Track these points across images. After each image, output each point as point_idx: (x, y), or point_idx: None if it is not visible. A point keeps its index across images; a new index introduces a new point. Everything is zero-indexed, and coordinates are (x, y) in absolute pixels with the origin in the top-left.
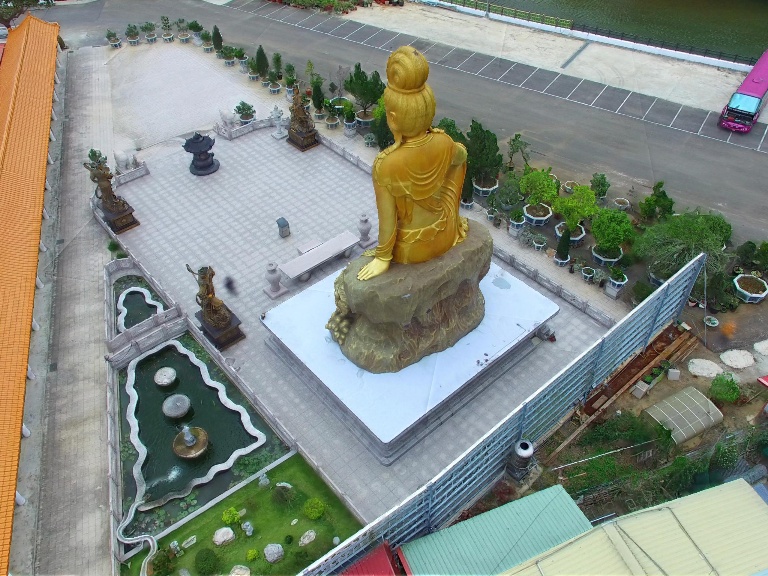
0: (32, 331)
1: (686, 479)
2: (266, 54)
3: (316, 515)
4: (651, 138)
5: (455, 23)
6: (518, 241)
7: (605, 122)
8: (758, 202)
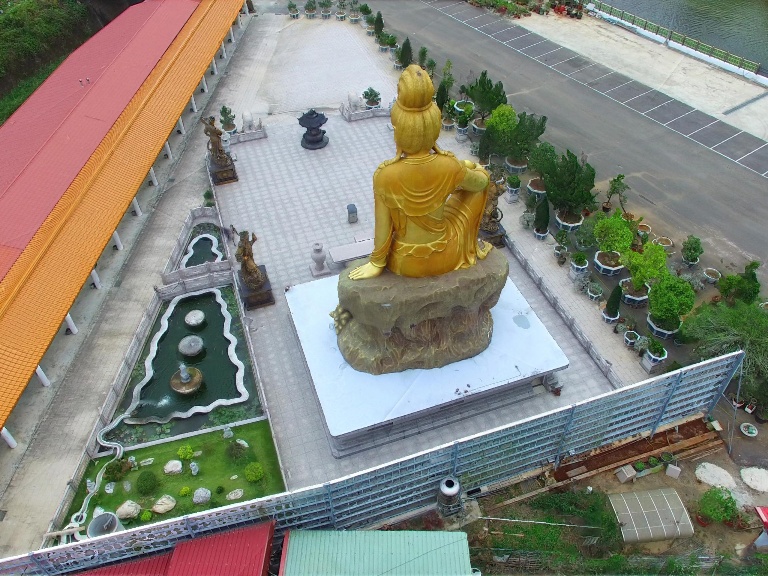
0: (116, 249)
1: None
2: None
3: (252, 478)
4: None
5: (627, 45)
6: None
7: (743, 183)
8: None
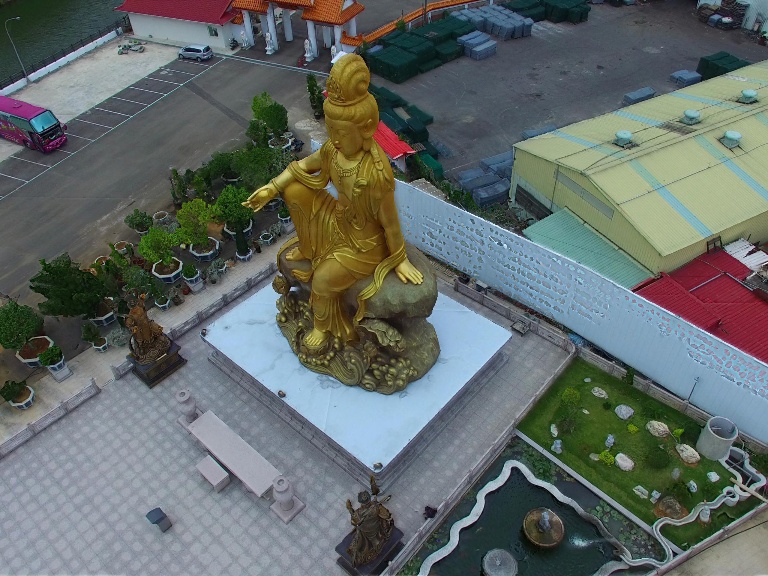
0: None
1: None
2: None
3: None
4: (46, 194)
5: None
6: (208, 287)
7: None
8: (173, 150)
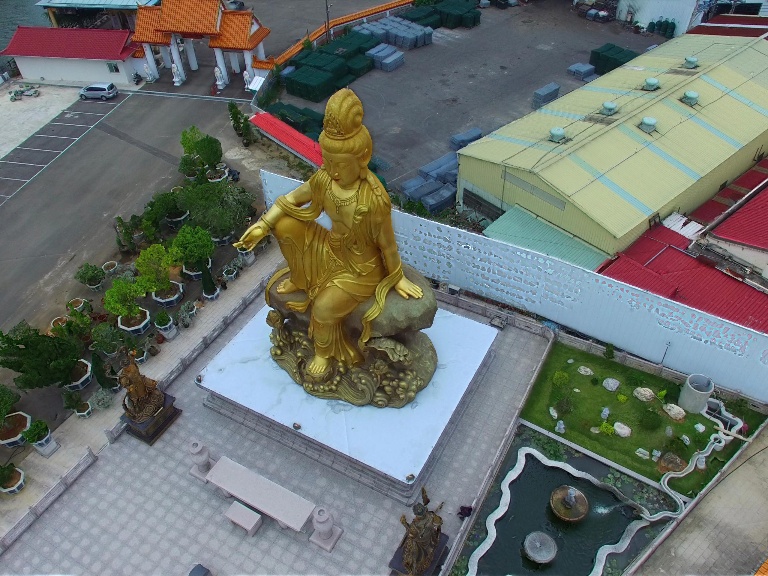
0: None
1: None
2: None
3: None
4: None
5: None
6: (182, 332)
7: None
8: (102, 196)
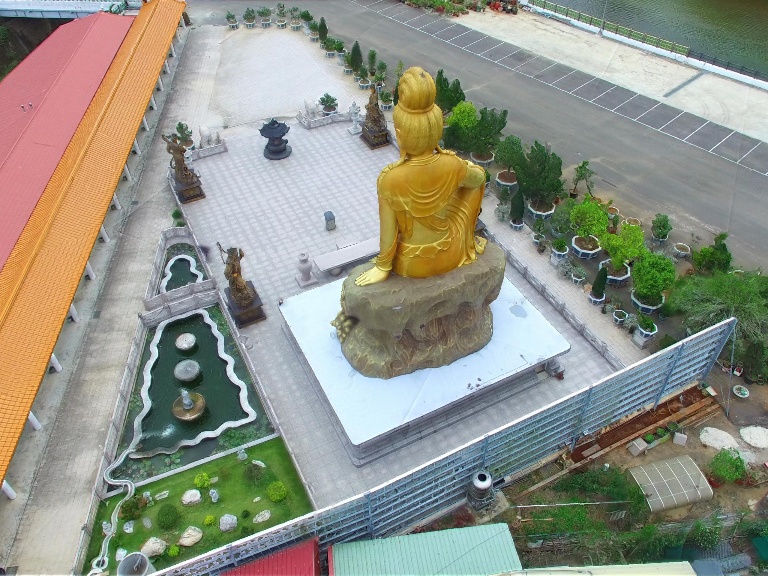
0: (89, 279)
1: (654, 549)
2: (367, 49)
3: (277, 498)
4: (740, 184)
5: (564, 37)
6: (558, 271)
7: (693, 160)
8: None
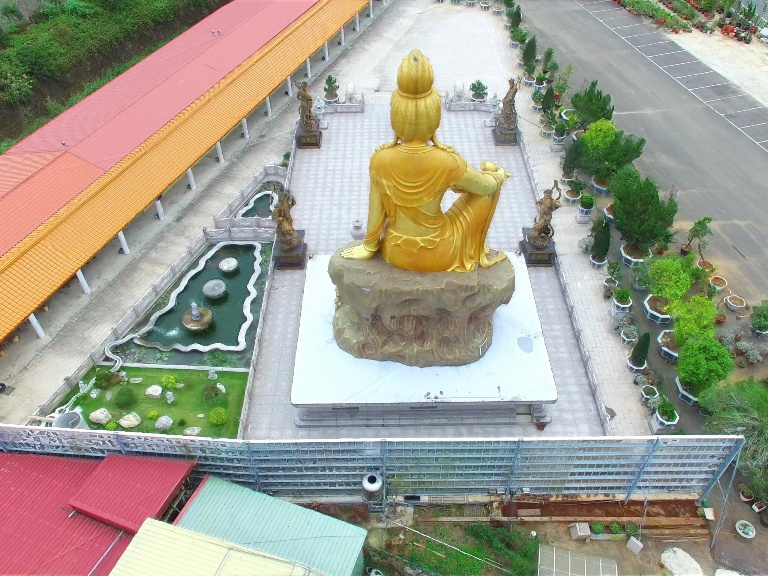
0: (190, 188)
1: None
2: (556, 47)
3: (214, 421)
4: None
5: None
6: None
7: None
8: None
